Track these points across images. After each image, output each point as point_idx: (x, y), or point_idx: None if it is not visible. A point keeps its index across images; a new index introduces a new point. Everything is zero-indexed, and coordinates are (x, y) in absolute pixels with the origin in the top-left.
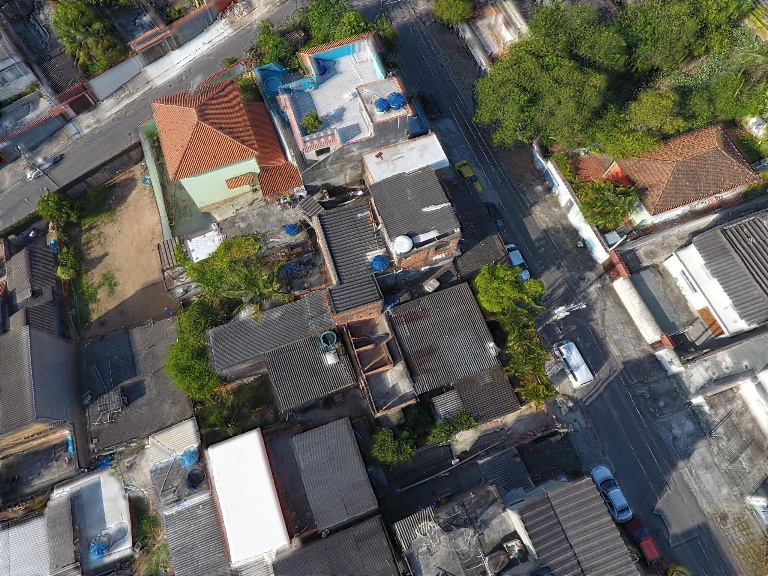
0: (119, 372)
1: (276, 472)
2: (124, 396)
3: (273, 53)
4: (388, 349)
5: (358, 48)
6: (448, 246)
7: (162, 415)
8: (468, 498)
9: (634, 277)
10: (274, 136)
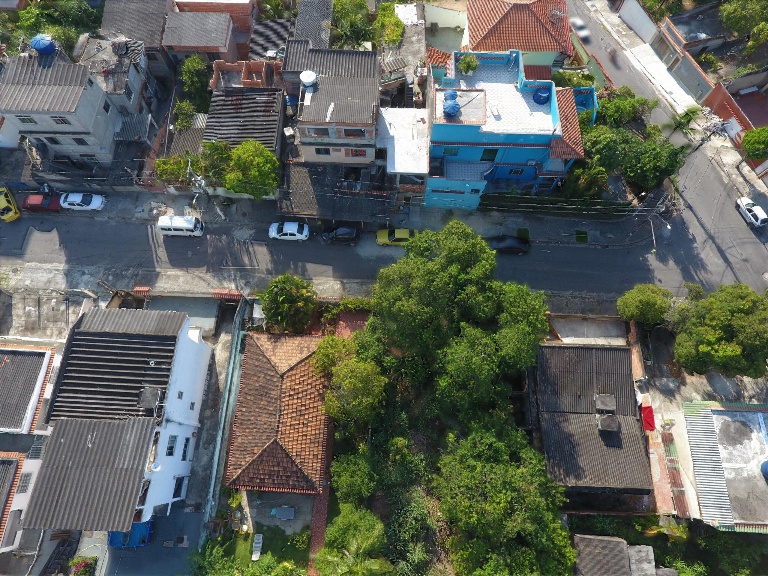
0: None
1: None
2: None
3: None
4: None
5: None
6: None
7: None
8: (127, 76)
9: (214, 310)
10: None
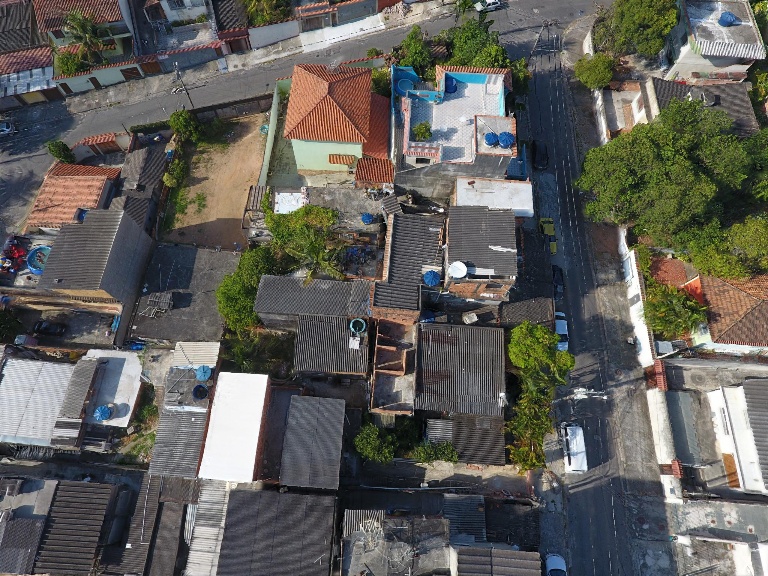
0: (176, 280)
1: (266, 420)
2: (172, 301)
3: (417, 58)
4: (406, 357)
5: (494, 81)
6: (499, 289)
7: (195, 330)
8: (419, 519)
9: (671, 394)
10: (387, 131)
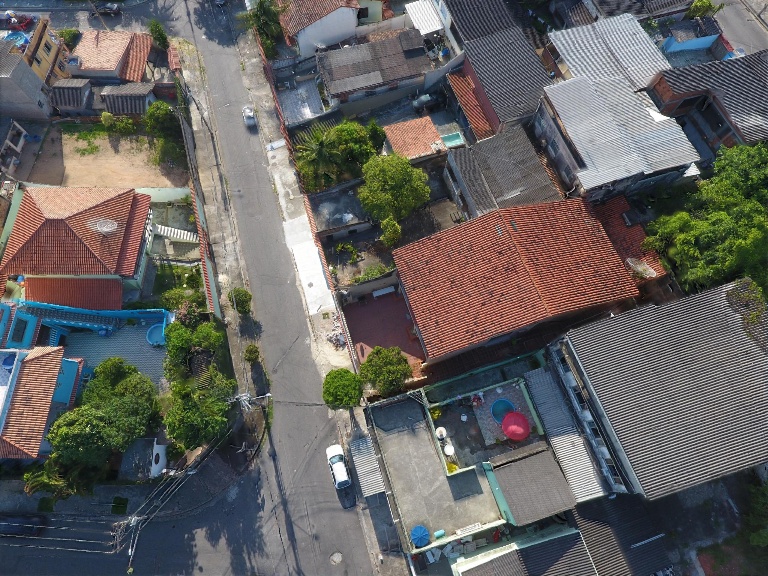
0: None
1: None
2: None
3: None
4: None
5: None
6: None
7: None
8: None
9: None
10: None
